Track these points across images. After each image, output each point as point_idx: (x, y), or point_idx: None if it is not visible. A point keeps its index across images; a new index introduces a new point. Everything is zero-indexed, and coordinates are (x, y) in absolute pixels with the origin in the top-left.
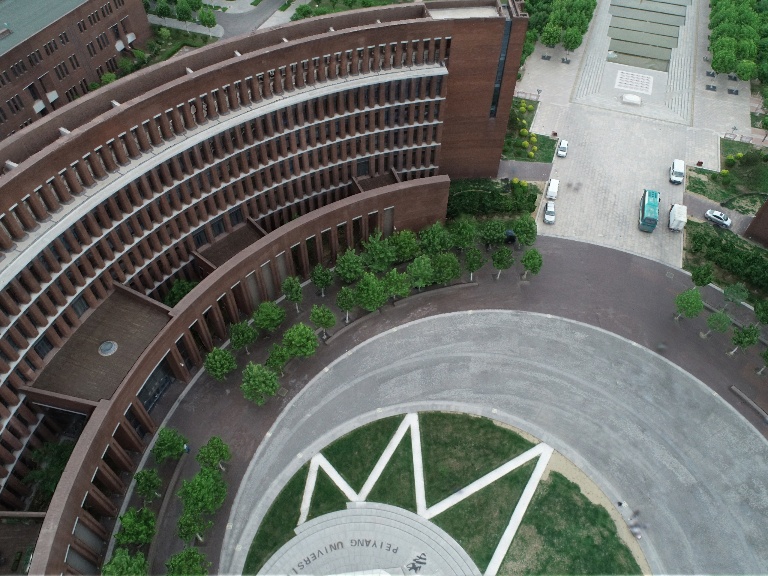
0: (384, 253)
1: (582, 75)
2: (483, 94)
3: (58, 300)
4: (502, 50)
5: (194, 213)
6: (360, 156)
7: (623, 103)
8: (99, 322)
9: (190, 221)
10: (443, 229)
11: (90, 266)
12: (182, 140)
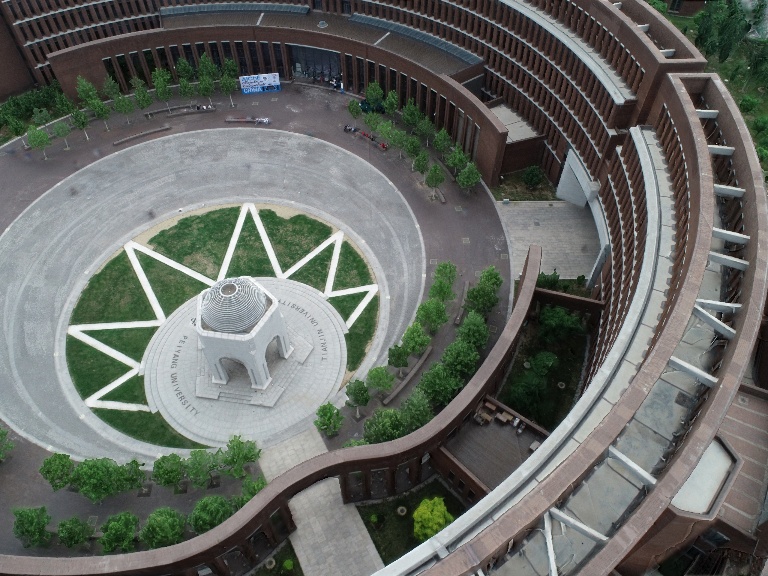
0: None
1: None
2: None
3: None
4: None
5: None
6: None
7: None
8: None
9: None
10: None
11: None
12: None
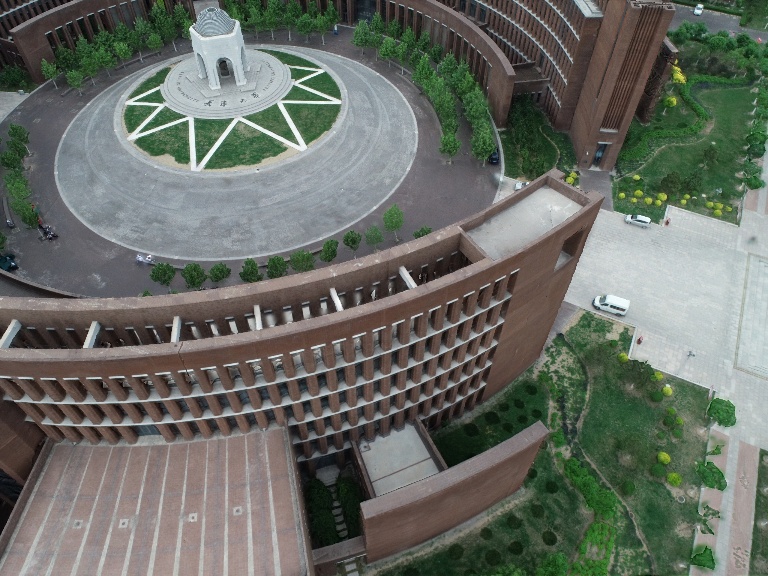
0: None
1: None
2: None
3: None
4: None
5: None
6: None
7: None
8: None
9: None
10: (479, 99)
11: None
12: None
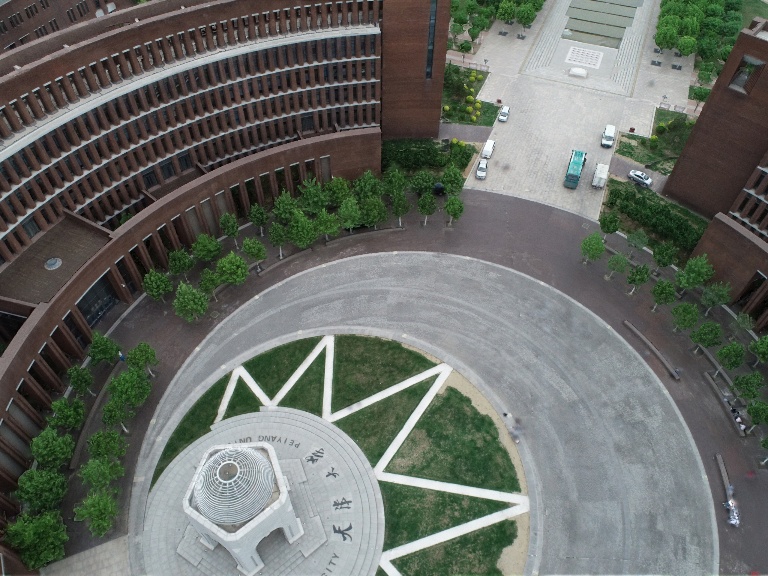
0: (318, 197)
1: (535, 50)
2: (418, 55)
3: (9, 218)
4: (432, 13)
5: (142, 153)
6: (303, 111)
7: (569, 75)
8: (48, 242)
9: (139, 161)
10: (374, 177)
11: (40, 191)
12: (128, 83)
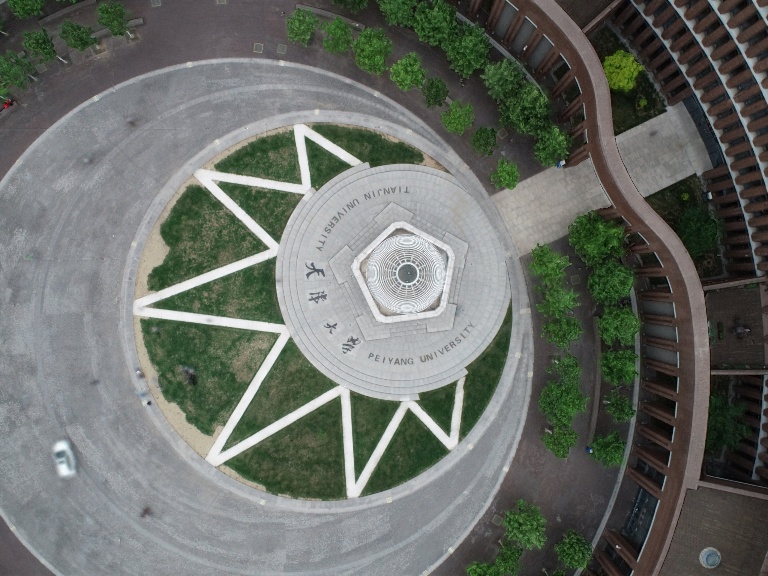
0: None
1: None
2: None
3: None
4: None
5: None
6: None
7: None
8: None
9: None
10: None
11: None
12: None
